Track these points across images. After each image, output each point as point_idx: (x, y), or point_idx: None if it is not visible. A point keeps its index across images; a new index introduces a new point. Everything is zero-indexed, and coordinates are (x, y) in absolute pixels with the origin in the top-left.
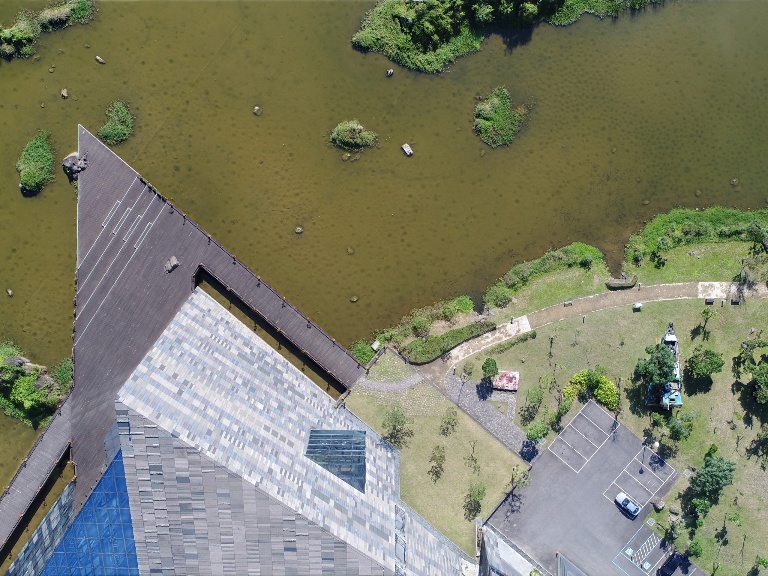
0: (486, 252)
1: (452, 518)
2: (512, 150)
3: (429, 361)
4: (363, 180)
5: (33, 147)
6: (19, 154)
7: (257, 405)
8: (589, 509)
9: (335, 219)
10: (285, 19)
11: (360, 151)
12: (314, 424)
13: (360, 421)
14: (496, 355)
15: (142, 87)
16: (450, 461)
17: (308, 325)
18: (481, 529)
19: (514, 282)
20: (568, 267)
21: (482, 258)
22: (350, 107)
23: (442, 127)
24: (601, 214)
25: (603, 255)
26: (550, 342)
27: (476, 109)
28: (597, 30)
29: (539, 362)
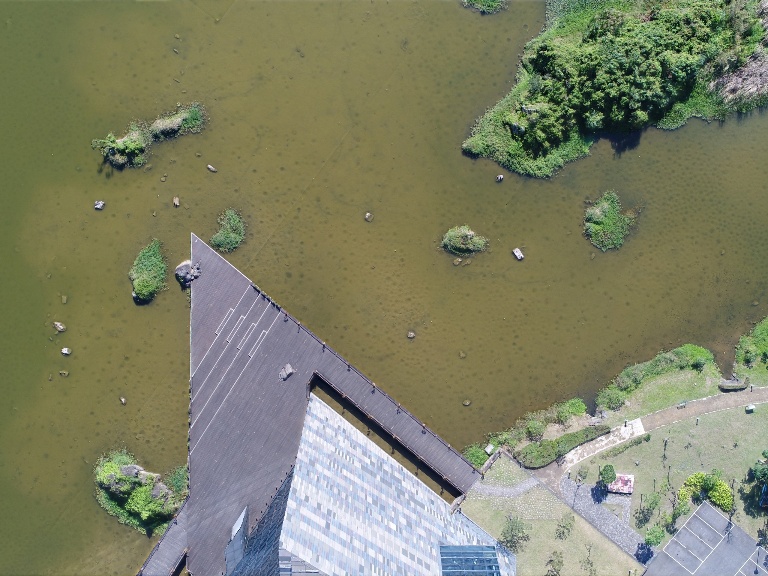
0: (597, 354)
1: None
2: (622, 253)
3: (544, 465)
4: (474, 284)
5: (146, 256)
6: (131, 263)
7: (390, 526)
8: None
9: (447, 323)
10: (395, 126)
11: (471, 256)
12: (440, 537)
13: (476, 526)
14: (610, 458)
15: (254, 195)
16: (566, 565)
17: (423, 431)
18: None
19: (627, 385)
20: (680, 369)
21: (593, 360)
22: (460, 212)
23: (552, 231)
24: (711, 315)
25: (714, 356)
26: (664, 444)
27: (586, 213)
28: (704, 134)
29: (653, 464)
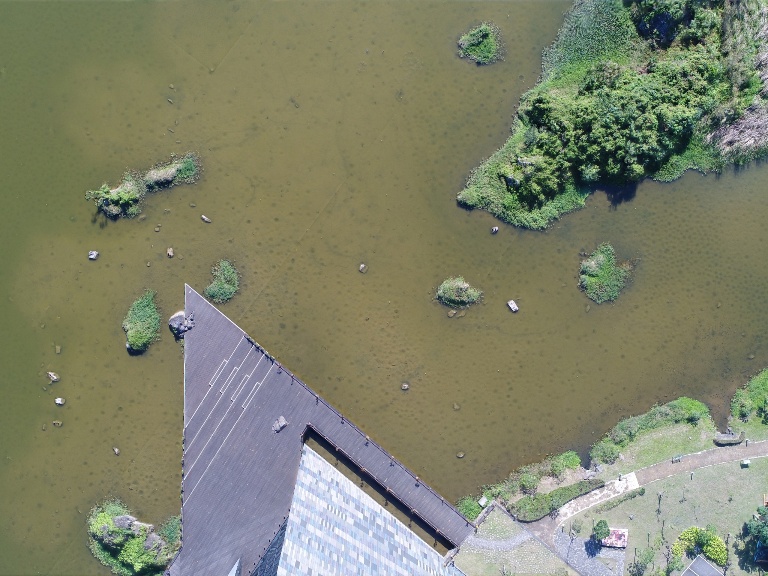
0: (592, 407)
1: None
2: (617, 305)
3: (538, 519)
4: (469, 336)
5: (140, 306)
6: (125, 313)
7: None
8: None
9: (441, 375)
10: (390, 177)
11: (466, 308)
12: None
13: None
14: (604, 512)
15: (248, 245)
16: None
17: (416, 484)
18: None
19: (622, 439)
20: (675, 423)
21: (588, 413)
22: (455, 264)
23: (547, 283)
24: (706, 368)
25: (709, 409)
26: (658, 499)
27: (581, 266)
28: (701, 186)
29: (647, 519)
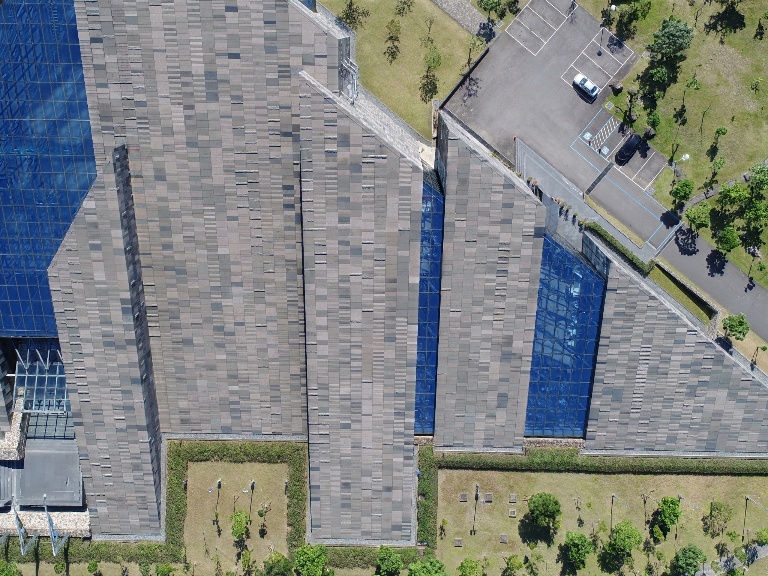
0: None
1: (408, 99)
2: None
3: None
4: None
5: None
6: None
7: None
8: (547, 93)
9: None
10: None
11: None
12: None
13: None
14: None
15: None
16: (406, 42)
17: None
18: (437, 110)
19: None
20: None
21: None
22: None
23: None
24: None
25: None
26: None
27: None
28: None
29: None
